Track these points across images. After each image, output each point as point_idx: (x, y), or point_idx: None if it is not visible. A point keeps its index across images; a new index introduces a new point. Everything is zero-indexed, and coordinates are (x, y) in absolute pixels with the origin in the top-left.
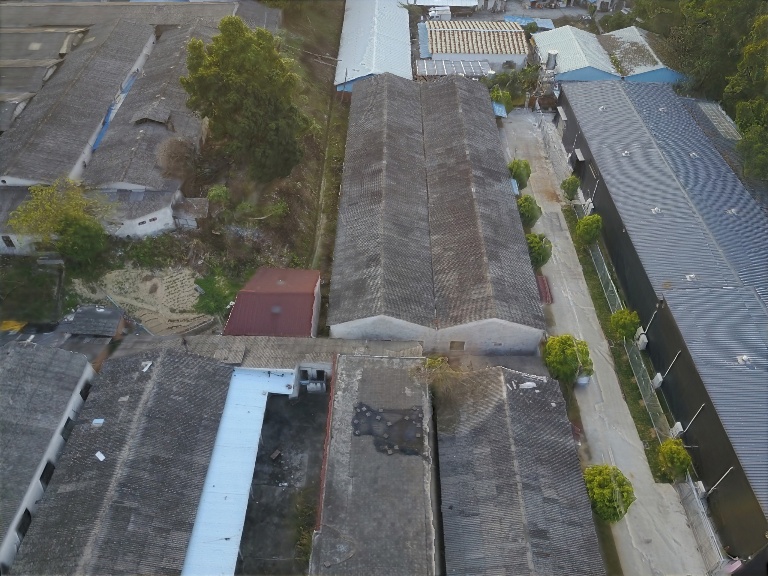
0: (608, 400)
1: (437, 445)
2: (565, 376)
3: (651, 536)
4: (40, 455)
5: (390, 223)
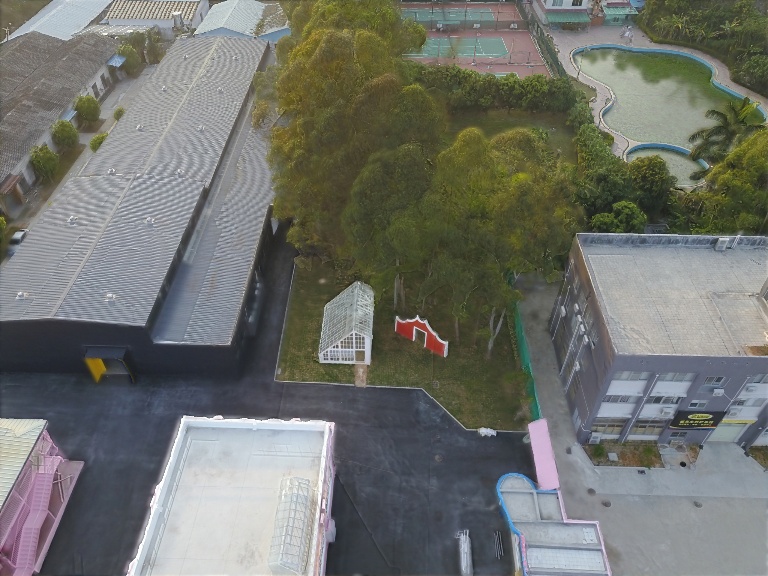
0: None
1: None
2: None
3: None
4: None
5: None
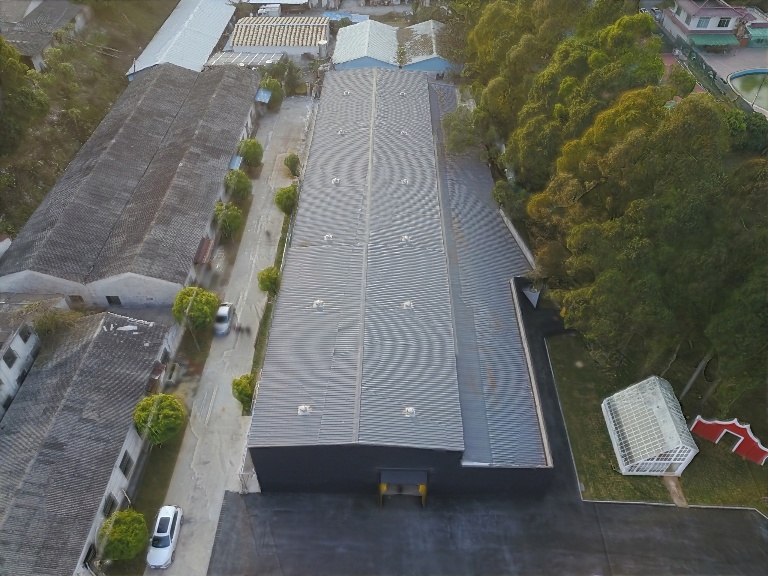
0: (239, 347)
1: (24, 378)
2: (185, 323)
3: (211, 459)
4: None
5: (86, 193)
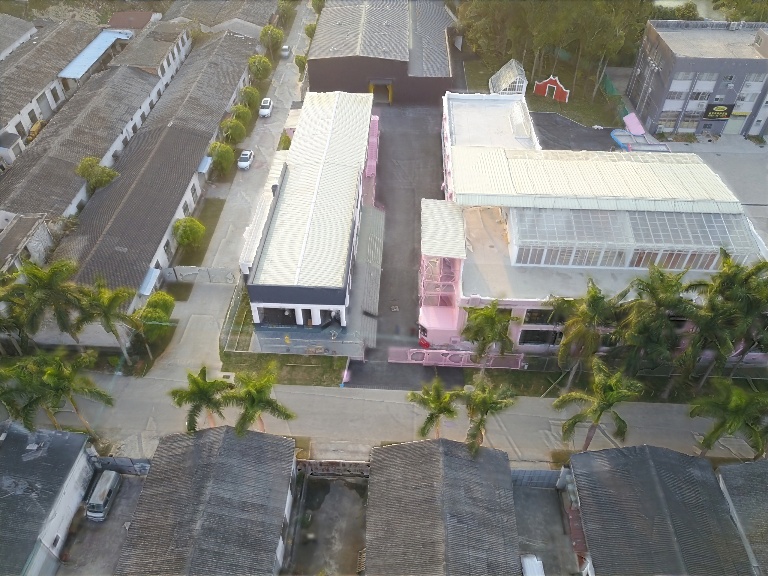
0: None
1: (190, 53)
2: (267, 43)
3: (284, 93)
4: (9, 44)
5: None
